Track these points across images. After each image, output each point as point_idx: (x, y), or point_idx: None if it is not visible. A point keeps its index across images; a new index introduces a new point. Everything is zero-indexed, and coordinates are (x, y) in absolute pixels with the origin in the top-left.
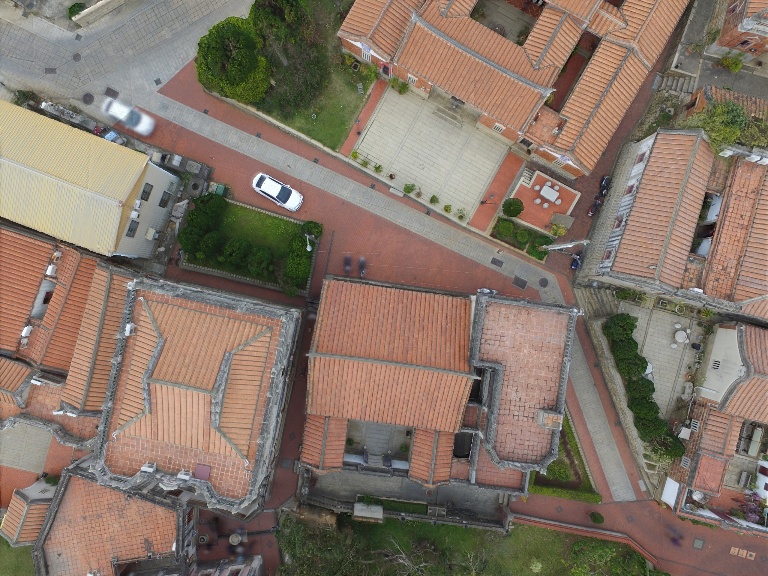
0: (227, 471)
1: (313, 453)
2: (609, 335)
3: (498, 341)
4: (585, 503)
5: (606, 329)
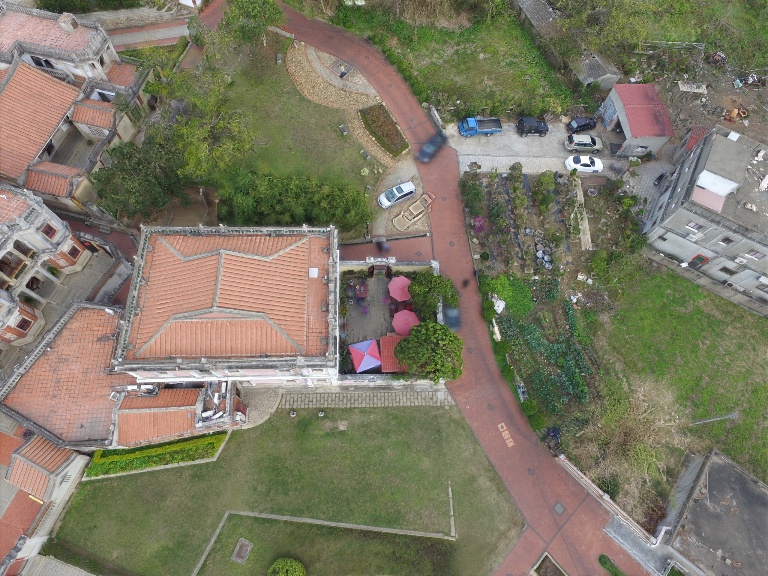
0: (6, 214)
1: (59, 185)
2: (54, 8)
3: (4, 46)
4: (191, 49)
5: (48, 8)
